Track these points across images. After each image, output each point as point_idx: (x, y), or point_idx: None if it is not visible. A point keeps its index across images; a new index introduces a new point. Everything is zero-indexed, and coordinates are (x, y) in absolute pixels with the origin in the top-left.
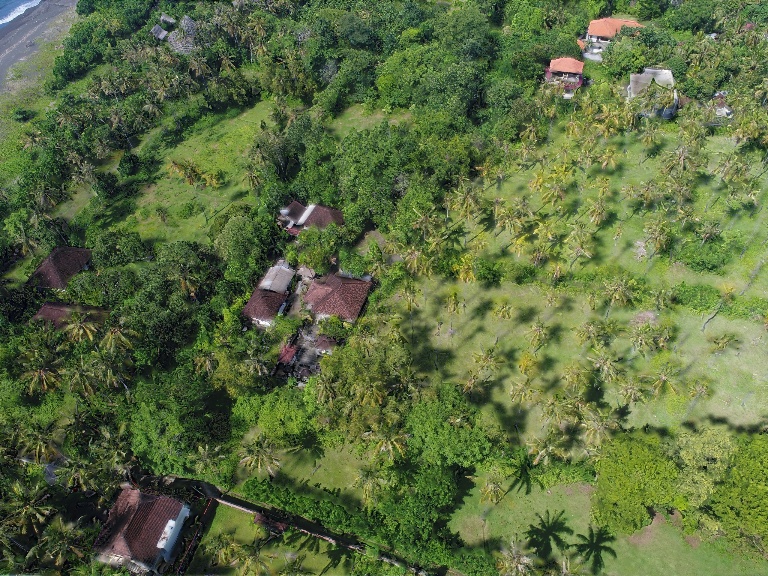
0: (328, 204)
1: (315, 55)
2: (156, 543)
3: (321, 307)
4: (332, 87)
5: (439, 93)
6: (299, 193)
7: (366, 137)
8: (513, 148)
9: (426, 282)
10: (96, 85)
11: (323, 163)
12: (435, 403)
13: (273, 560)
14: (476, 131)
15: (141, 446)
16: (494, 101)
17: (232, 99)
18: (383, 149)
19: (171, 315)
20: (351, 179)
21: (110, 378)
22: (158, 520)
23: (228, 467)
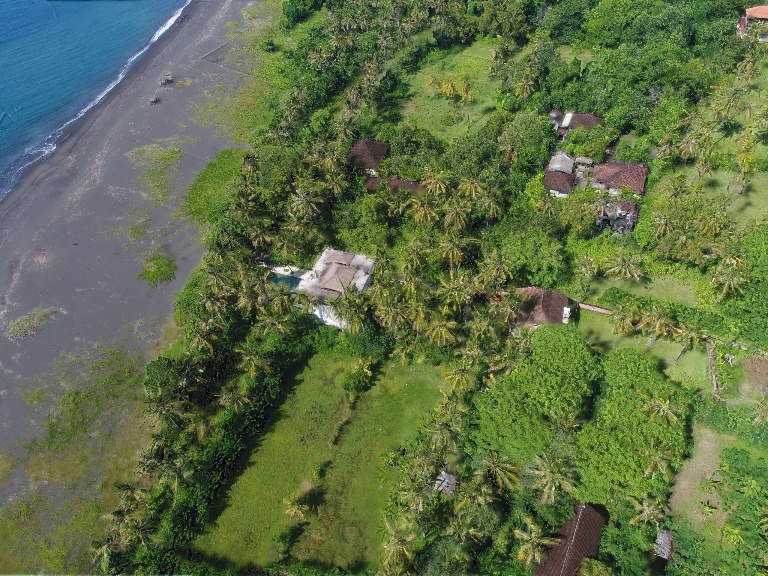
0: (584, 113)
1: (526, 2)
2: (561, 320)
3: (613, 182)
4: (543, 29)
5: (658, 30)
6: (555, 104)
7: (618, 57)
8: (728, 77)
9: (687, 171)
10: (337, 22)
11: (567, 83)
12: (761, 234)
13: (638, 345)
14: (697, 61)
15: (519, 261)
16: (713, 36)
17: (458, 36)
18: (639, 65)
19: (495, 181)
20: (610, 90)
21: (492, 209)
22: (558, 305)
23: (577, 286)
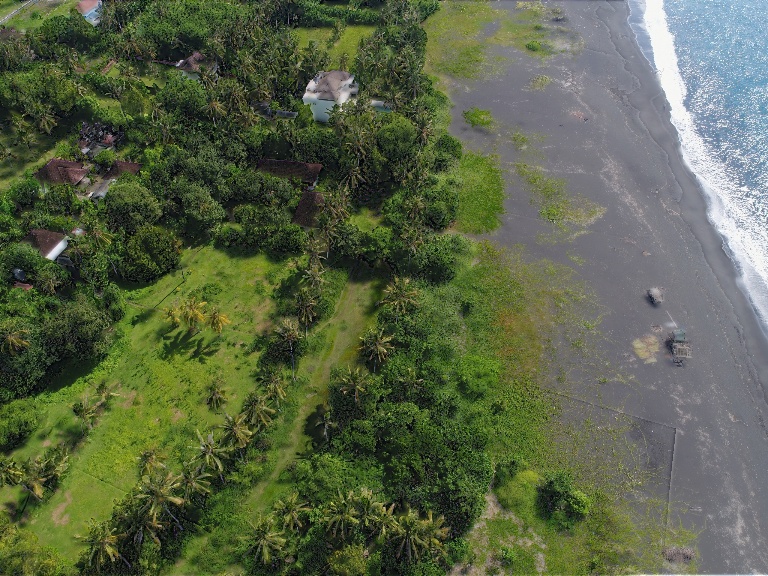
0: None
1: None
2: None
3: (73, 162)
4: None
5: None
6: None
7: None
8: None
9: None
10: None
11: None
12: None
13: None
14: None
15: None
16: None
17: None
18: None
19: None
20: None
21: None
22: None
23: None
